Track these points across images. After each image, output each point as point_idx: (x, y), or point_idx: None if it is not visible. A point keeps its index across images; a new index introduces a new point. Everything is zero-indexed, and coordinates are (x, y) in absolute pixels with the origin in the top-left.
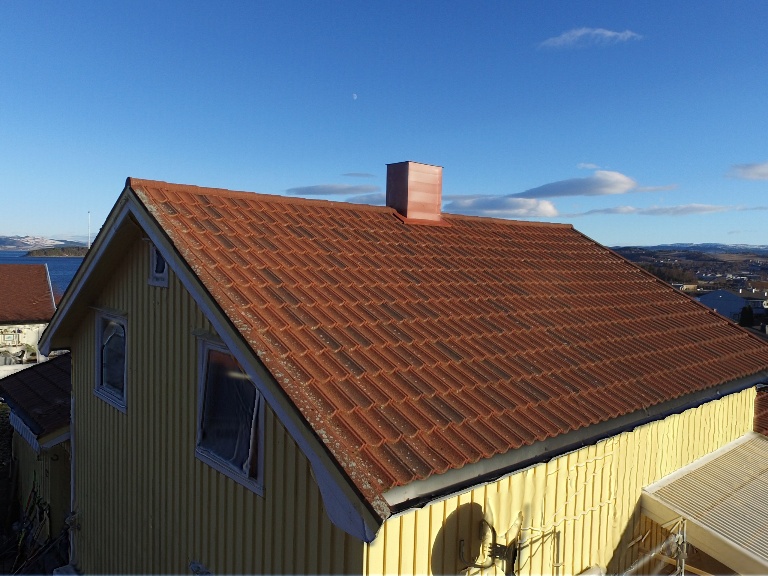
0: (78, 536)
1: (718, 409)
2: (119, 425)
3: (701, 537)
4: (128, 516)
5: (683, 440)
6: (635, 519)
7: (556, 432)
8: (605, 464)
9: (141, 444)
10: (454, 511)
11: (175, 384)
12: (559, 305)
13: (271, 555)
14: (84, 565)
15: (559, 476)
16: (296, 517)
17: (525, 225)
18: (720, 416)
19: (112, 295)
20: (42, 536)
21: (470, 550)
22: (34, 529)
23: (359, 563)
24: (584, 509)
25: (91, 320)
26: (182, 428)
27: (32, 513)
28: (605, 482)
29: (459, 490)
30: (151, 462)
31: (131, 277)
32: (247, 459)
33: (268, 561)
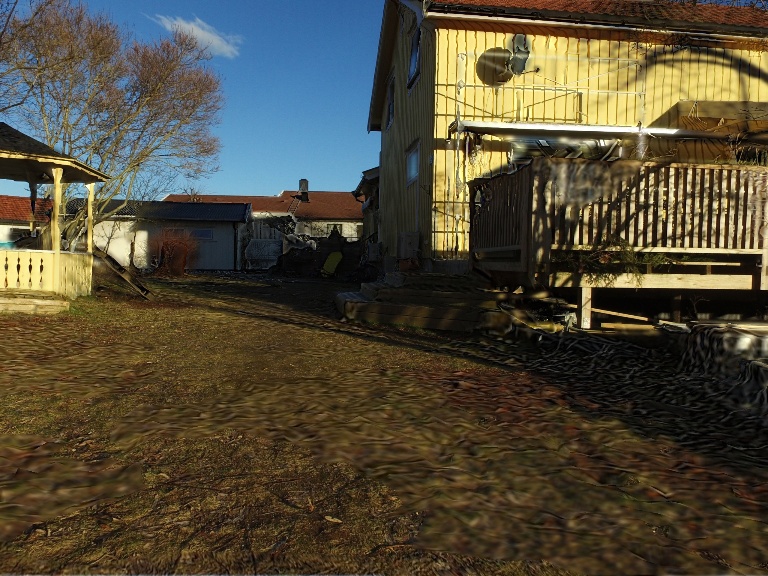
0: None
1: None
2: None
3: (704, 108)
4: None
5: (740, 80)
6: (671, 118)
7: (552, 8)
8: (630, 66)
9: None
10: (492, 48)
11: None
12: (649, 9)
13: None
14: None
15: (580, 59)
16: None
17: (694, 5)
18: None
19: None
20: None
21: (502, 71)
22: None
23: None
24: (608, 89)
25: (386, 93)
26: None
27: None
28: (630, 78)
29: (472, 9)
30: None
31: (396, 45)
32: None
33: None
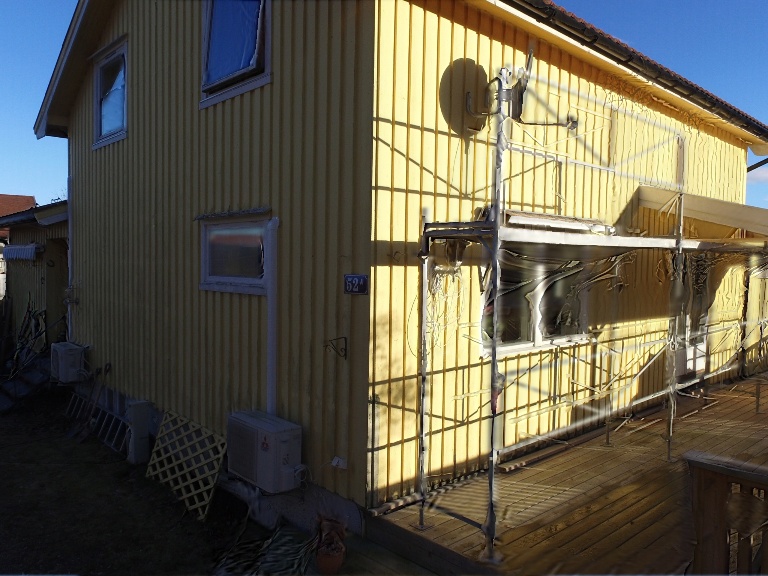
0: (76, 311)
1: (711, 157)
2: (119, 156)
3: (698, 205)
4: (129, 239)
5: (678, 162)
6: (633, 208)
7: (559, 7)
8: (604, 127)
9: (143, 153)
10: (461, 59)
11: (178, 58)
12: None
13: (279, 133)
14: (83, 335)
15: (560, 104)
16: (305, 70)
17: None
18: (713, 165)
19: (111, 31)
20: (38, 344)
21: (476, 108)
22: (29, 343)
23: (370, 49)
24: (584, 160)
25: (89, 77)
26: (186, 97)
27: (27, 331)
28: (604, 145)
29: None
30: (153, 161)
31: None
32: (254, 53)
33: (276, 140)
